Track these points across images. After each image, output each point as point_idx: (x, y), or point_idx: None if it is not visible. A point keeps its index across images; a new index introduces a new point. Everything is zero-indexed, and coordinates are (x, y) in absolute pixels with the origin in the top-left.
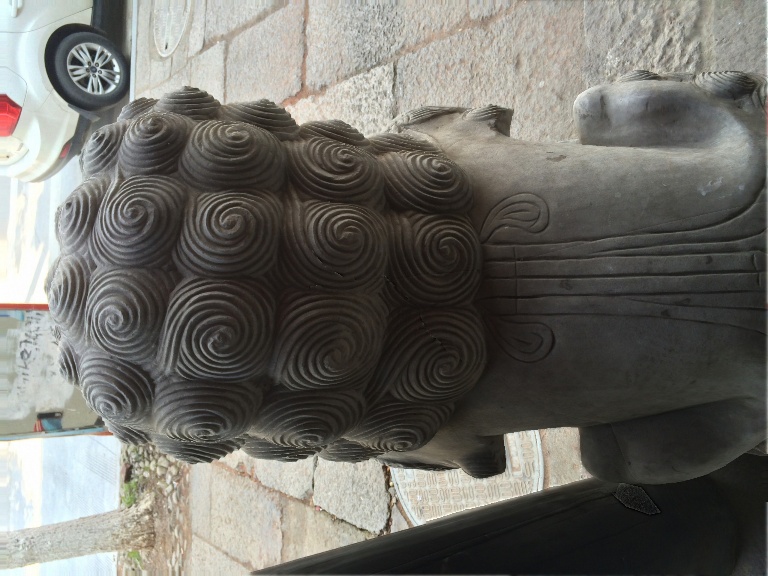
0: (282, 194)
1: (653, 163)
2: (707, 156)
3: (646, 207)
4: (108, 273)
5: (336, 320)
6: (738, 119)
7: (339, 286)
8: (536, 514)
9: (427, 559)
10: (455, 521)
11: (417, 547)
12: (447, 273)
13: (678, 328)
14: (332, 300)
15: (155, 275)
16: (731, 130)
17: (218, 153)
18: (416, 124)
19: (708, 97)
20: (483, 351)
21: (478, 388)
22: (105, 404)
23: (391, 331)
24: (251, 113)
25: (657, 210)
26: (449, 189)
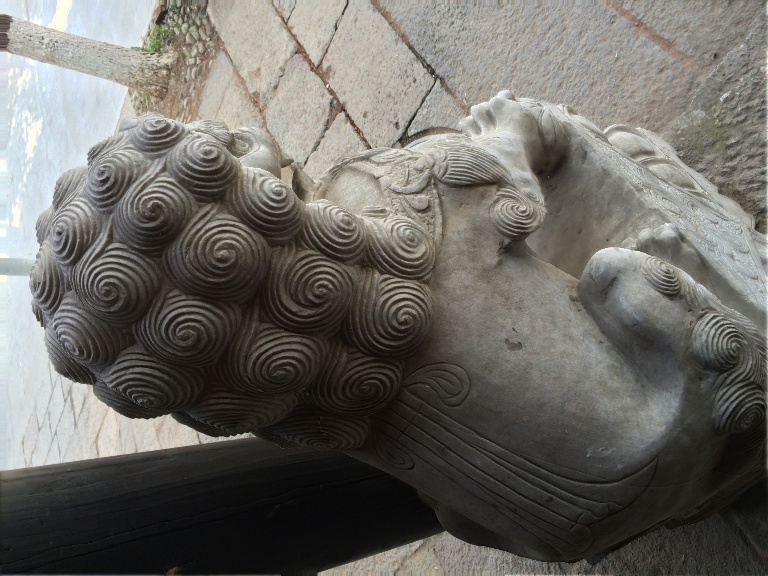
0: (246, 308)
1: (578, 402)
2: (629, 413)
3: (538, 441)
4: (77, 309)
5: (246, 414)
6: (684, 396)
7: (259, 393)
8: (372, 471)
9: (264, 503)
10: (310, 459)
11: (264, 487)
12: (358, 400)
13: (498, 516)
14: (249, 401)
15: (114, 333)
16: (670, 401)
17: (199, 269)
18: (447, 186)
19: (685, 355)
20: (360, 444)
21: (348, 450)
22: (57, 370)
23: (293, 415)
24: (254, 214)
25: (543, 448)
26: (398, 342)
